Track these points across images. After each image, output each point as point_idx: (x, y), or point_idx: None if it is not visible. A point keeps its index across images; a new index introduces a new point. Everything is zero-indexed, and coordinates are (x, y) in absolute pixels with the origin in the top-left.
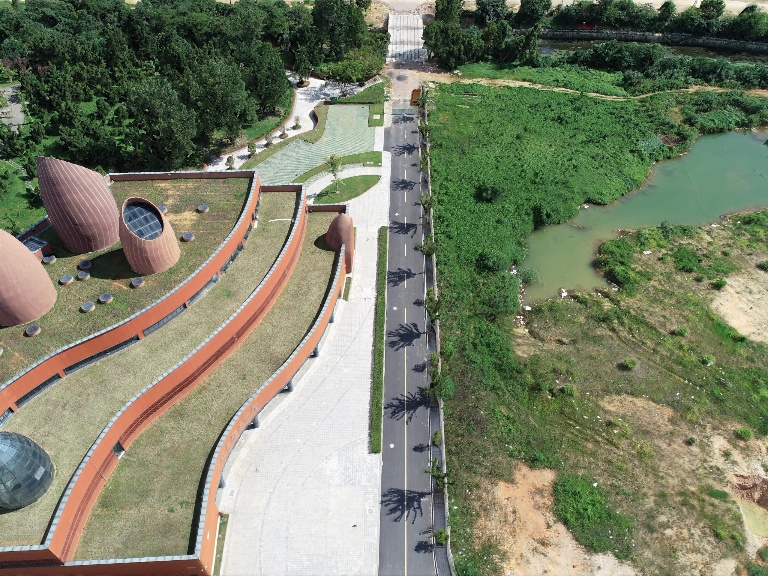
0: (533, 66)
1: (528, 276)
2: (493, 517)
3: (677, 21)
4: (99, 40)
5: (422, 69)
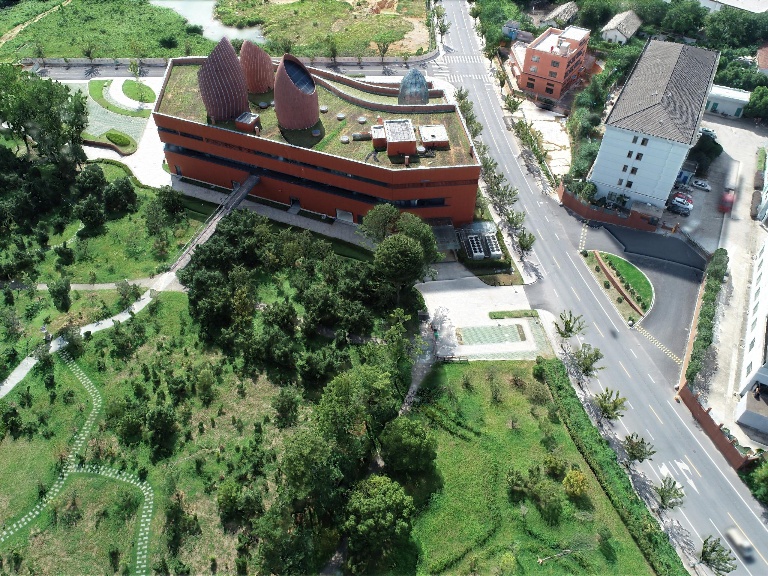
0: None
1: None
2: (393, 54)
3: None
4: None
5: None
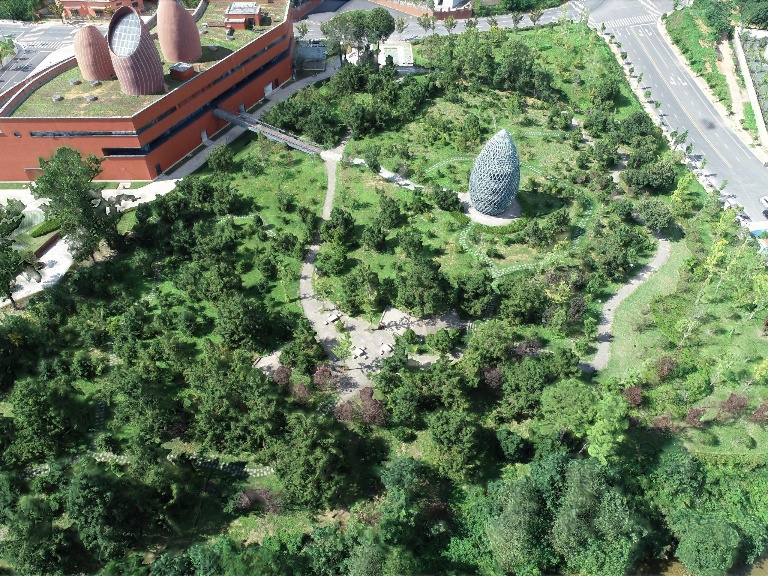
0: None
1: None
2: None
3: None
4: None
5: None
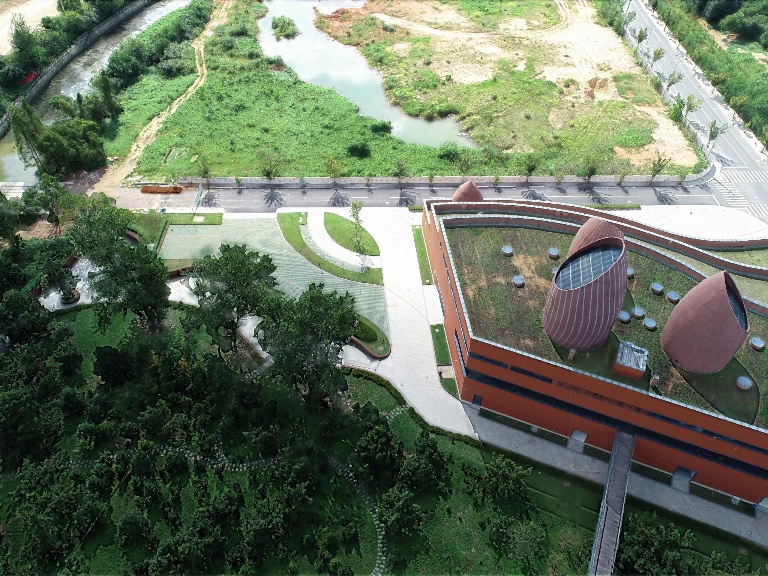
0: (121, 111)
1: (452, 145)
2: None
3: (68, 28)
4: None
5: (87, 185)
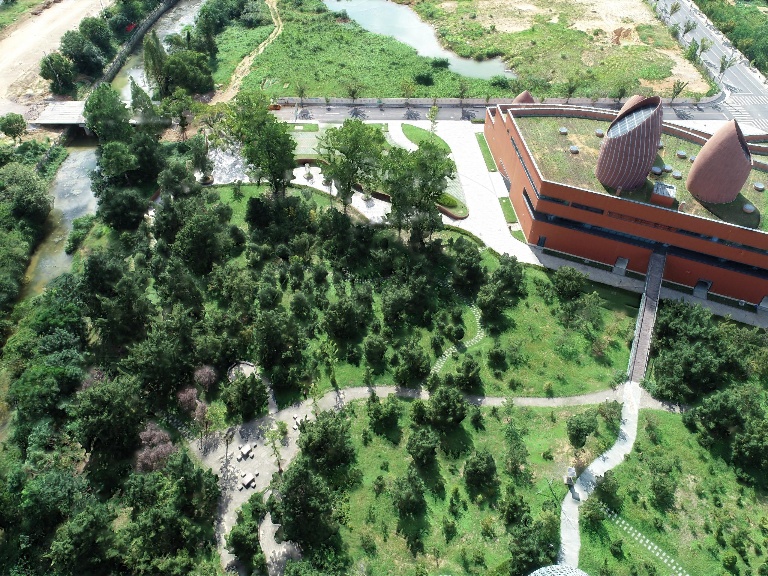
0: (217, 51)
1: None
2: None
3: None
4: None
5: (201, 103)
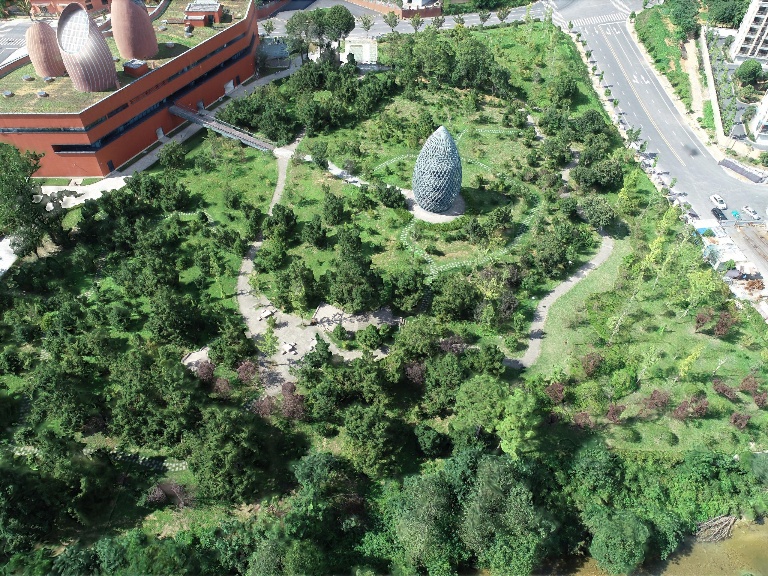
0: None
1: None
2: None
3: None
4: (127, 570)
5: None
